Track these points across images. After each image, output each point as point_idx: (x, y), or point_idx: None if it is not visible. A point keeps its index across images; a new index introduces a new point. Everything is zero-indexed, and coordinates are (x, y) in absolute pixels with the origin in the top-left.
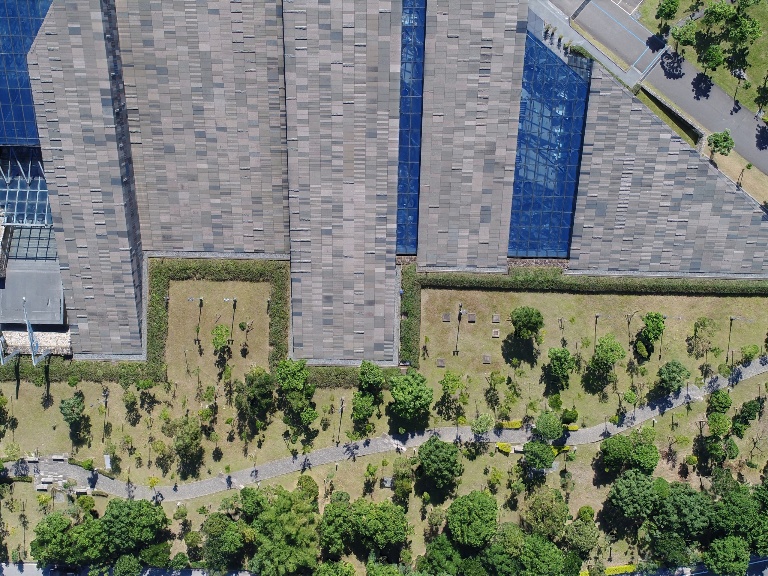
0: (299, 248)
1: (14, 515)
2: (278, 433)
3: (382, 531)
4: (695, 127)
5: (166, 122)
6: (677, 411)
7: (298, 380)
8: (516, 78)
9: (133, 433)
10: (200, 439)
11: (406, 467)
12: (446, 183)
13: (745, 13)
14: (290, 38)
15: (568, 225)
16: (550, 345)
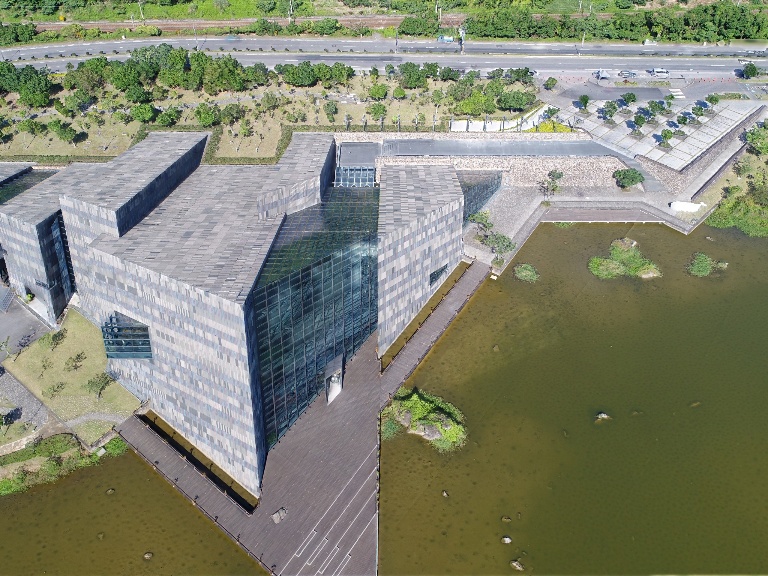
0: None
1: None
2: None
3: None
4: None
5: None
6: None
7: None
8: None
9: (304, 111)
10: None
11: None
12: None
13: None
14: None
15: None
16: None
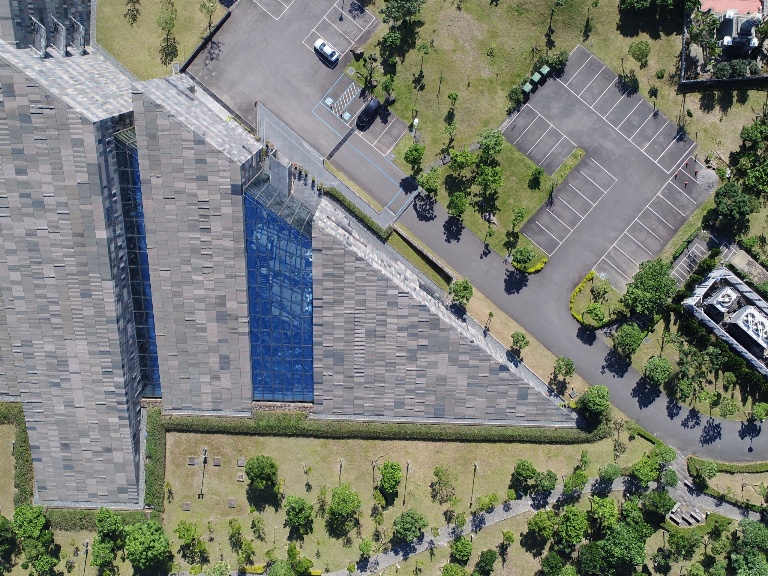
0: (30, 399)
1: None
2: (23, 575)
3: None
4: (445, 270)
5: None
6: (421, 556)
7: (34, 527)
8: (237, 237)
9: None
10: None
11: None
12: (181, 333)
13: (494, 158)
14: None
15: (311, 371)
16: (295, 489)
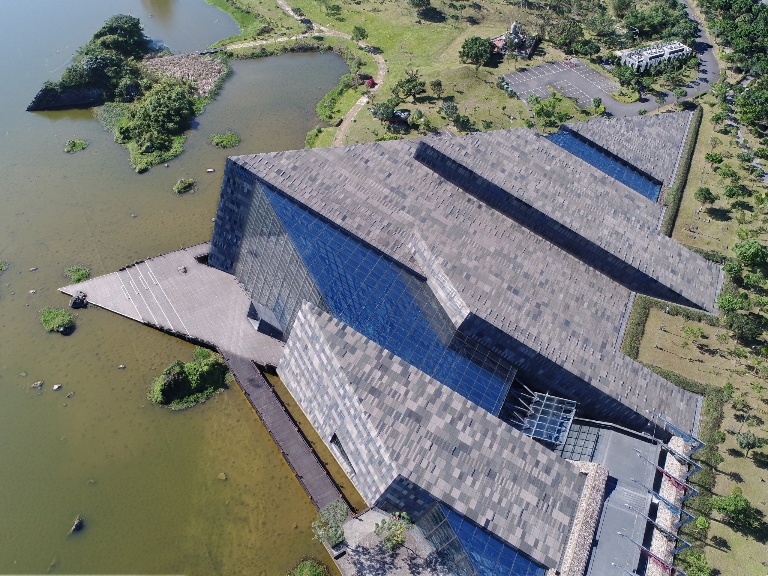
0: (637, 264)
1: None
2: None
3: None
4: None
5: None
6: (766, 169)
7: None
8: (561, 150)
9: None
10: None
11: None
12: None
13: None
14: (516, 194)
15: None
16: (718, 203)
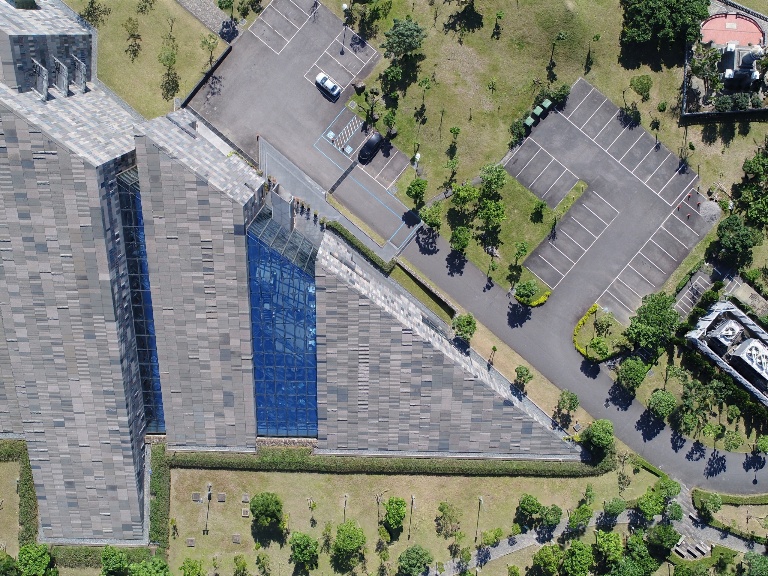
0: (34, 438)
1: None
2: None
3: None
4: (448, 304)
5: None
6: None
7: (39, 566)
8: (240, 276)
9: None
10: None
11: None
12: (185, 370)
13: (496, 191)
14: None
15: (315, 407)
16: (299, 525)
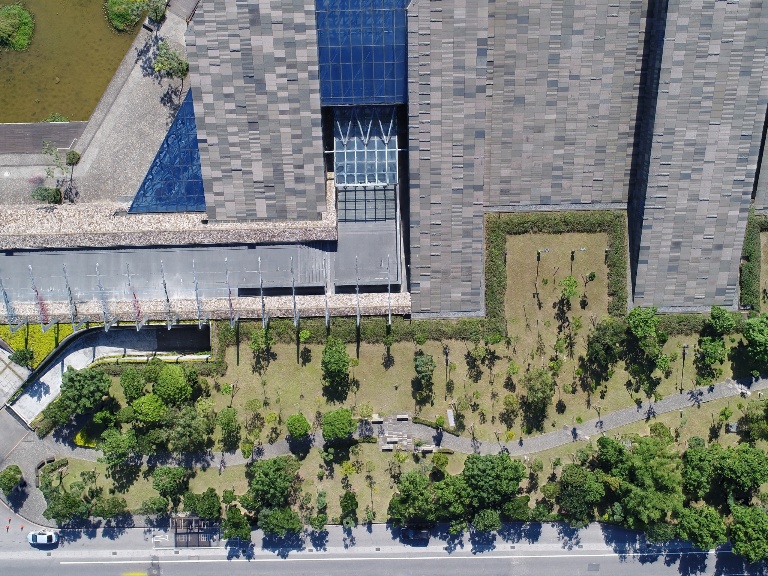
0: (655, 194)
1: (360, 476)
2: (620, 383)
3: (747, 473)
4: None
5: (520, 73)
6: None
7: (650, 327)
8: None
9: (475, 389)
10: (553, 391)
11: (760, 410)
12: None
13: None
14: None
15: None
16: None
